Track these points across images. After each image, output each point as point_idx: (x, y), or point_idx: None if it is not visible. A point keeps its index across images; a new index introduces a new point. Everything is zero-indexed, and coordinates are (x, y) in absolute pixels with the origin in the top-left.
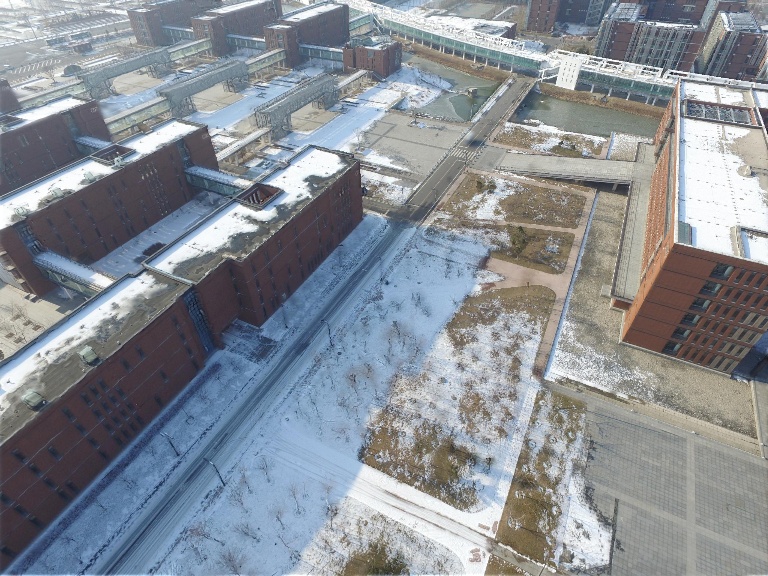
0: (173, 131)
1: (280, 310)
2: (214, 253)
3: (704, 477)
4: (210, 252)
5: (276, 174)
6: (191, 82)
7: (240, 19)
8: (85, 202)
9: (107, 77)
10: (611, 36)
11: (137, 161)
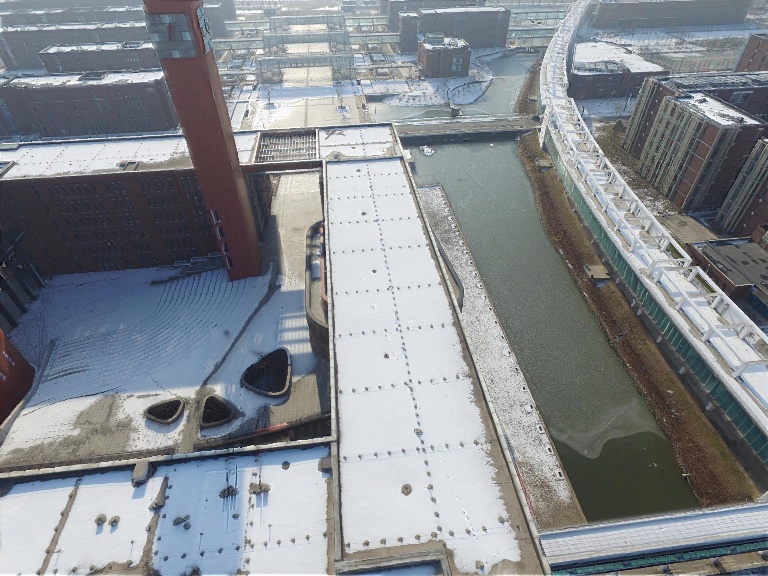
0: None
1: (59, 137)
2: (30, 84)
3: None
4: (31, 83)
5: (124, 73)
6: (287, 34)
7: (426, 6)
8: (89, 58)
9: (288, 24)
10: (651, 103)
11: (125, 49)
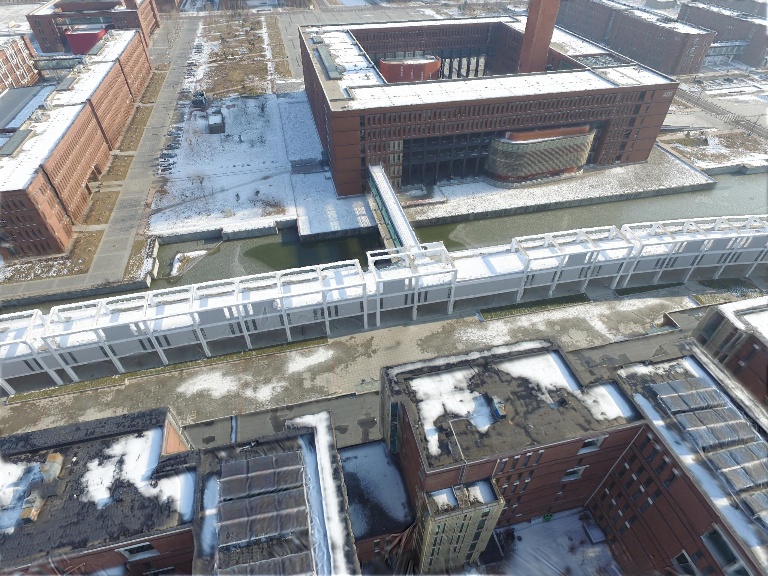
0: None
1: None
2: None
3: (473, 61)
4: None
5: None
6: None
7: None
8: None
9: None
10: None
11: (733, 17)
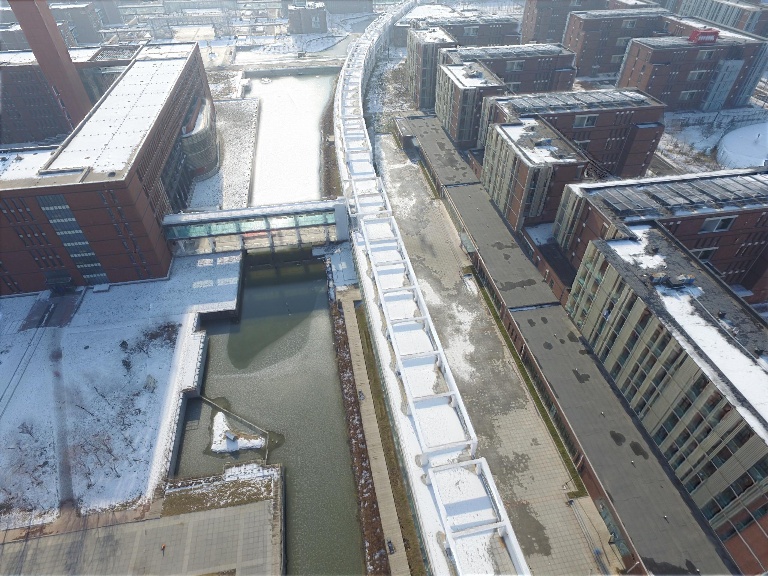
0: (77, 6)
1: None
2: None
3: None
4: None
5: None
6: (184, 1)
7: None
8: (5, 17)
9: None
10: None
11: None
